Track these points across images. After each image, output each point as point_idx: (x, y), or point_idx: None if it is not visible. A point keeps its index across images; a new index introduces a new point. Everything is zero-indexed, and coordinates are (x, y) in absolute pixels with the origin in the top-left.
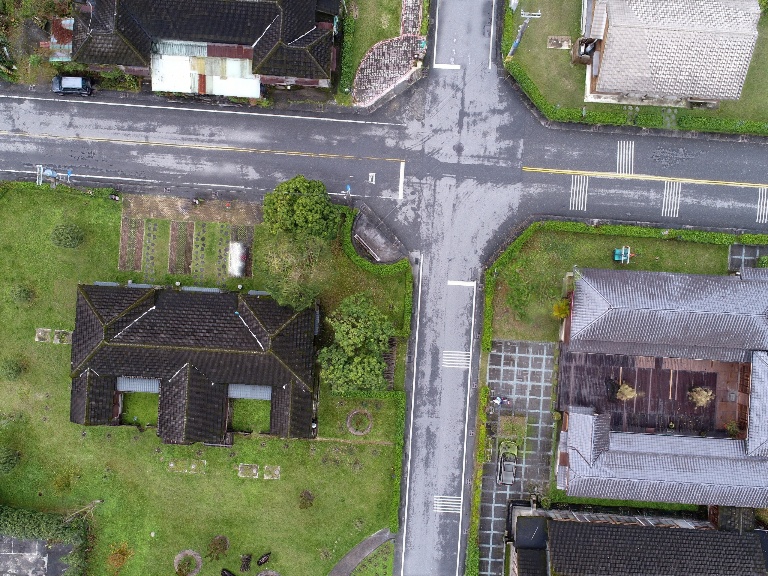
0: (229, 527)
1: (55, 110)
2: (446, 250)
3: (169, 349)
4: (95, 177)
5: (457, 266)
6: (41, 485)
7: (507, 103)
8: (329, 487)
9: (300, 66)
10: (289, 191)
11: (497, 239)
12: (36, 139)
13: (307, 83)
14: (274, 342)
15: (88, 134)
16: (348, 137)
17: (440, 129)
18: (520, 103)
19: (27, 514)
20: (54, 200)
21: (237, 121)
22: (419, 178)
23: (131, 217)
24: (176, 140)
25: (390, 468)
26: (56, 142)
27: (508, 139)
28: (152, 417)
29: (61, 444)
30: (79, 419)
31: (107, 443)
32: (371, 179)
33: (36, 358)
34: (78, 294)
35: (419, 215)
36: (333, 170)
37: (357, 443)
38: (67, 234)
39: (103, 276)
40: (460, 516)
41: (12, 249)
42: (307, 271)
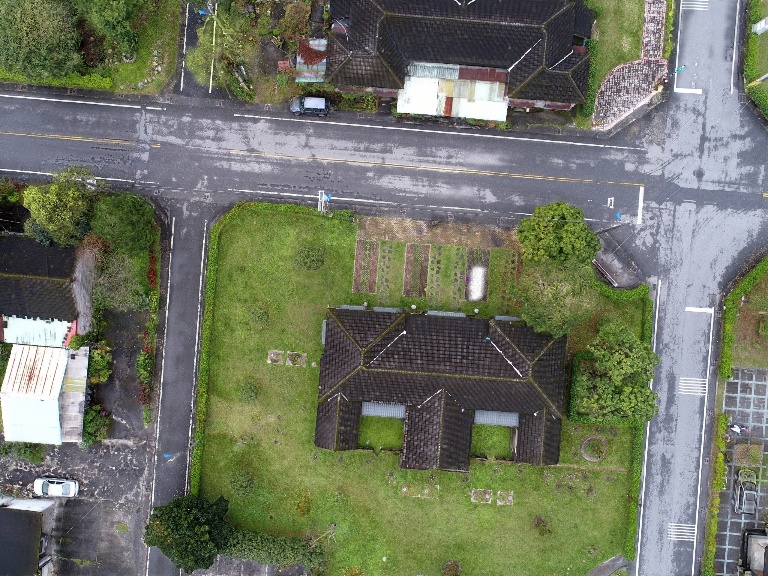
0: (461, 553)
1: (291, 130)
2: (684, 276)
3: (427, 375)
4: (330, 198)
5: (695, 292)
6: (272, 508)
7: (748, 128)
8: (562, 513)
9: (559, 91)
10: (553, 218)
11: (736, 266)
12: (271, 159)
13: (559, 107)
14: (533, 370)
15: (324, 155)
16: (587, 161)
17: (681, 154)
18: (761, 129)
19: (270, 539)
20: (289, 221)
21: (475, 143)
22: (658, 203)
23: (366, 239)
24: (413, 162)
25: (624, 495)
26: (291, 162)
27: (749, 165)
28: (385, 441)
29: (292, 467)
30: (327, 444)
31: (339, 466)
32: (610, 203)
33: (268, 380)
34: (328, 318)
35: (657, 240)
36: (571, 194)
37: (591, 469)
38: (313, 257)
39: (337, 298)
40: (694, 544)
41: (245, 270)
42: (579, 300)
